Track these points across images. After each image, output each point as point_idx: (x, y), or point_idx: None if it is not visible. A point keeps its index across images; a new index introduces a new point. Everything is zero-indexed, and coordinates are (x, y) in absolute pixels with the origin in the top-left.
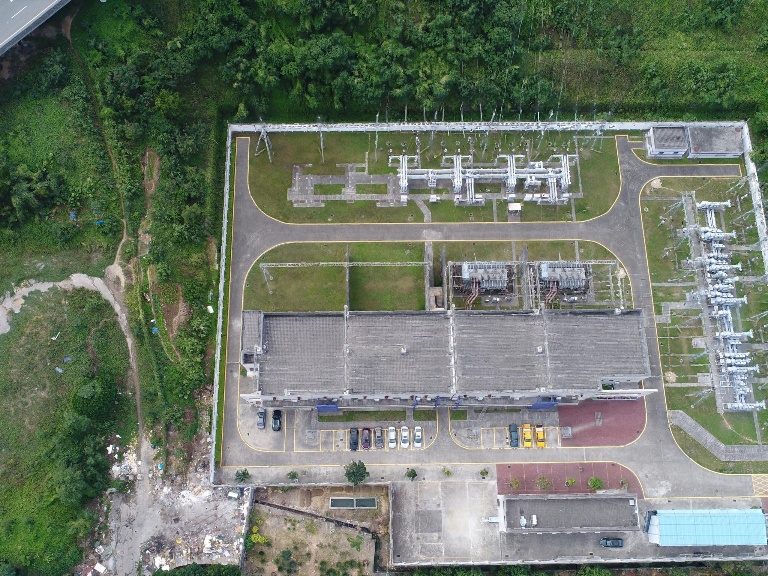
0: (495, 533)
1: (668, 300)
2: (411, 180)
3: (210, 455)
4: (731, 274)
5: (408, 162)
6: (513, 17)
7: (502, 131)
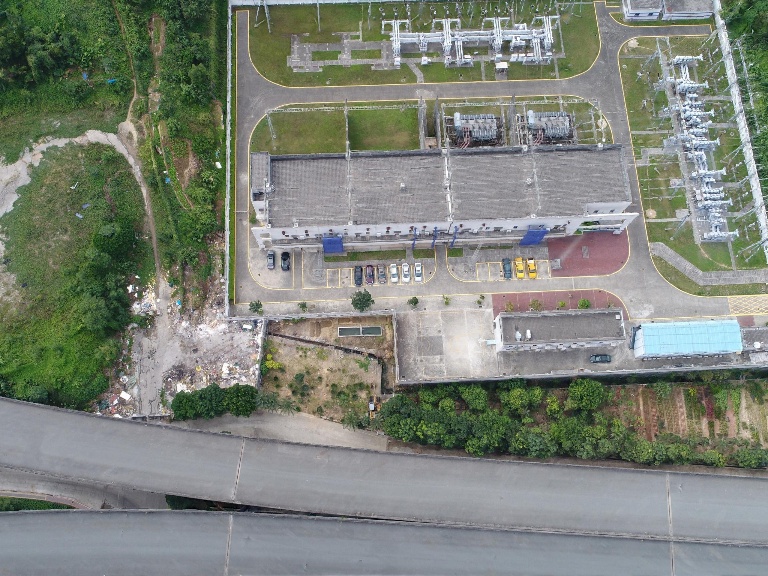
0: (493, 354)
1: (647, 146)
2: (403, 45)
3: None
4: (705, 122)
5: (400, 29)
6: None
7: None
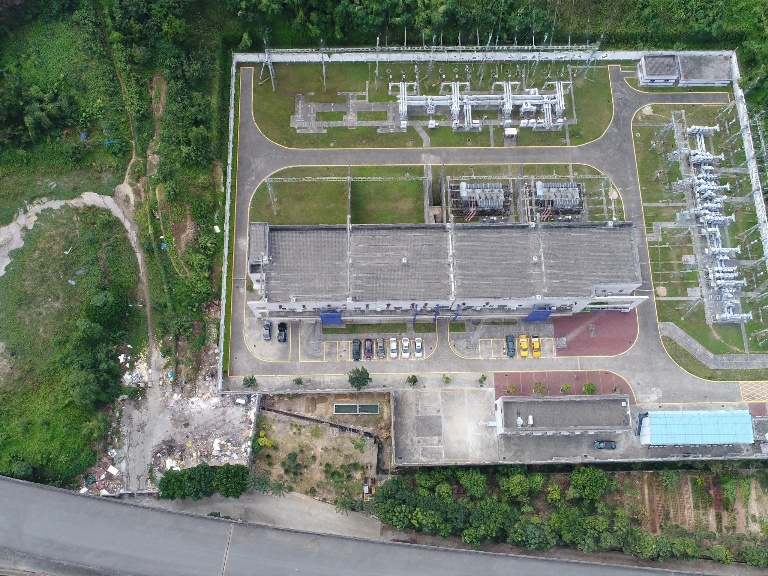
0: (493, 437)
1: (659, 219)
2: (410, 107)
3: (218, 364)
4: (720, 195)
5: (407, 90)
6: None
7: (498, 61)
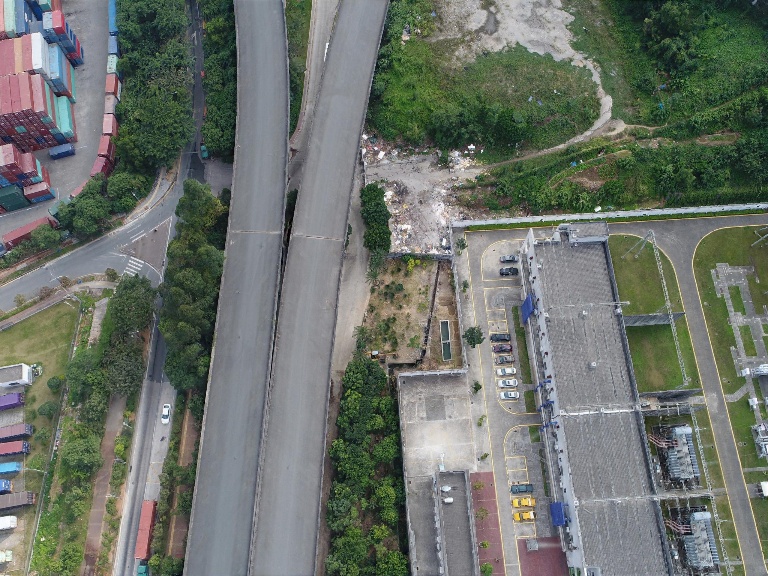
0: (430, 470)
1: None
2: (767, 379)
3: (475, 220)
4: None
5: None
6: None
7: None
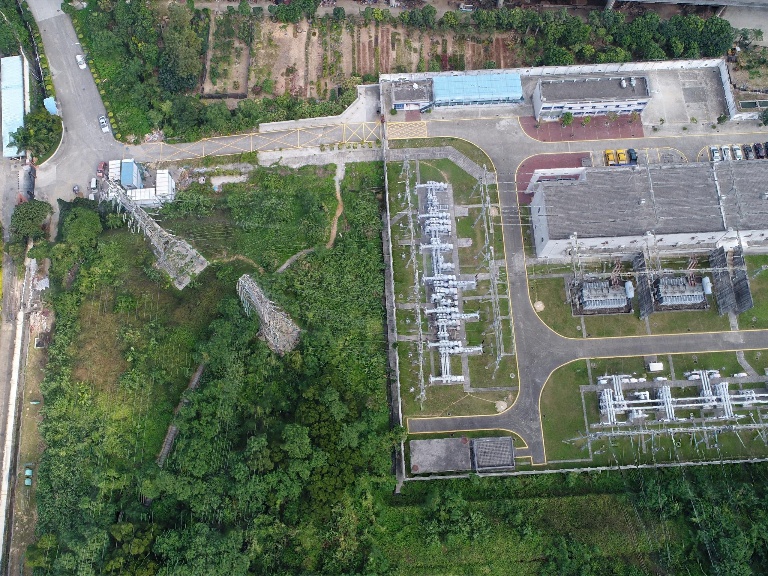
0: None
1: None
2: (767, 398)
3: None
4: None
5: None
6: (729, 568)
7: None
